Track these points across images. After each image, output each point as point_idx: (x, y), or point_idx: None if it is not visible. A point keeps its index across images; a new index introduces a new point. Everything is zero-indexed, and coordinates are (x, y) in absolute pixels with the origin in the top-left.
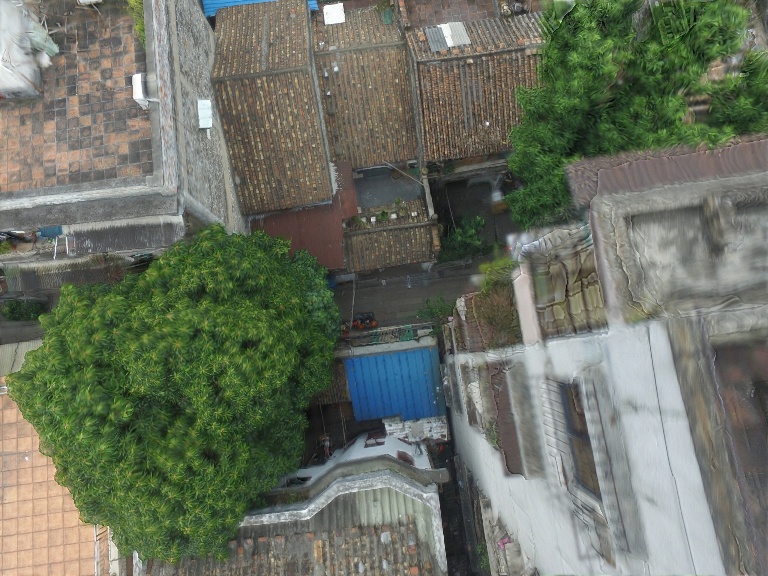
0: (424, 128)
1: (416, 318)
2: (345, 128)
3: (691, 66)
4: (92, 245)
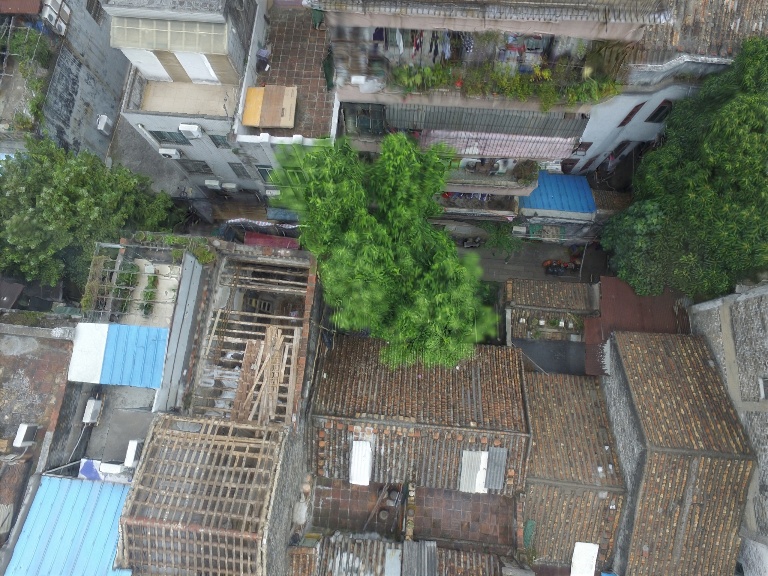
0: (521, 377)
1: (508, 262)
2: (588, 413)
3: (386, 249)
4: None
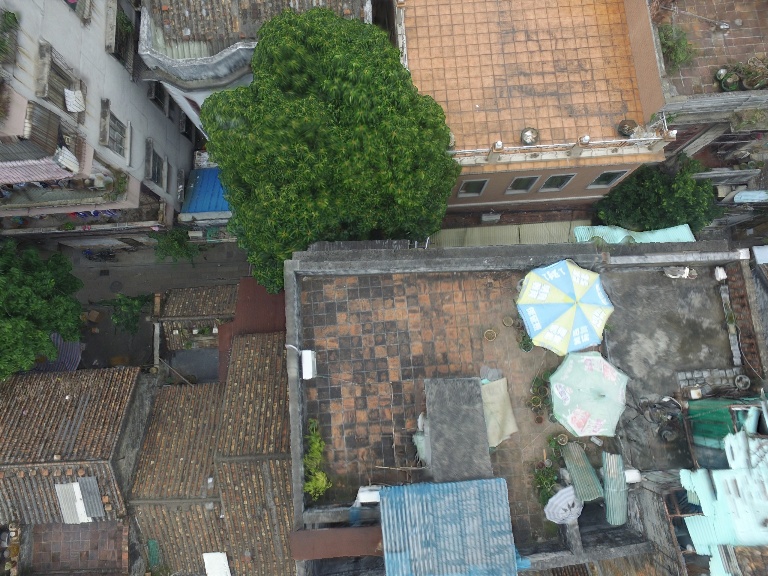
0: None
1: (220, 264)
2: None
3: None
4: (393, 247)
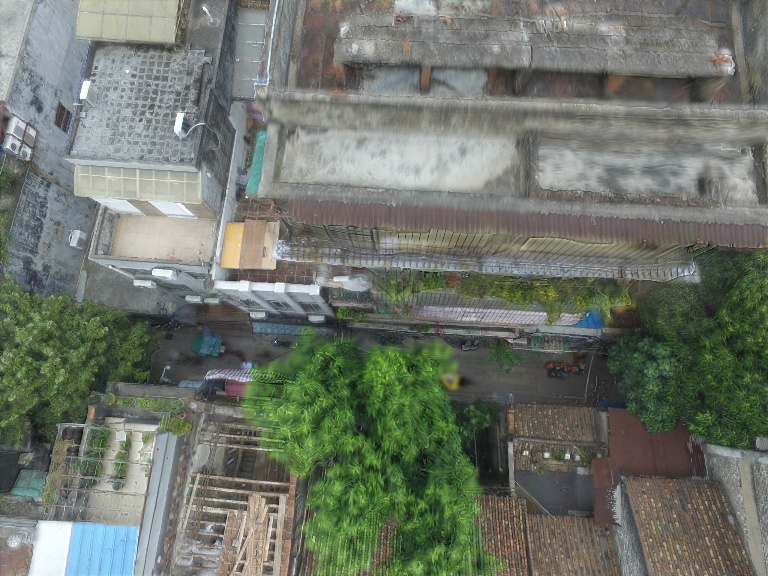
0: (526, 536)
1: None
2: (598, 566)
3: (374, 473)
4: None
